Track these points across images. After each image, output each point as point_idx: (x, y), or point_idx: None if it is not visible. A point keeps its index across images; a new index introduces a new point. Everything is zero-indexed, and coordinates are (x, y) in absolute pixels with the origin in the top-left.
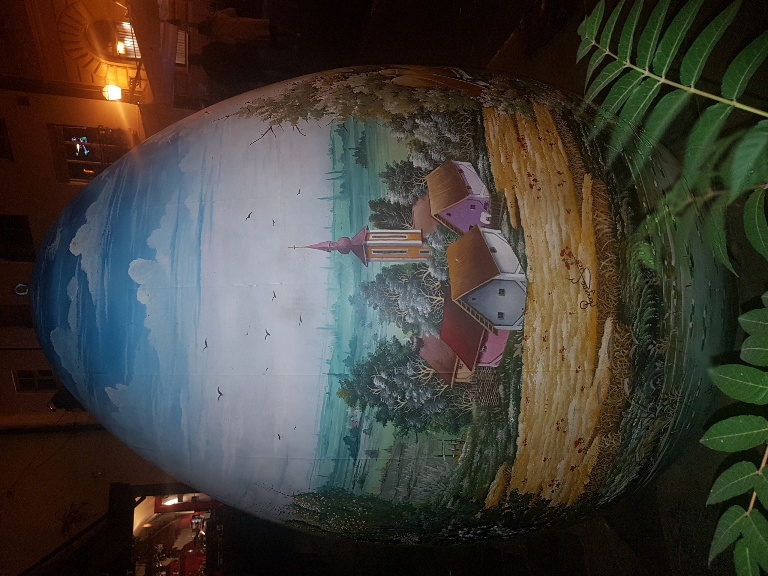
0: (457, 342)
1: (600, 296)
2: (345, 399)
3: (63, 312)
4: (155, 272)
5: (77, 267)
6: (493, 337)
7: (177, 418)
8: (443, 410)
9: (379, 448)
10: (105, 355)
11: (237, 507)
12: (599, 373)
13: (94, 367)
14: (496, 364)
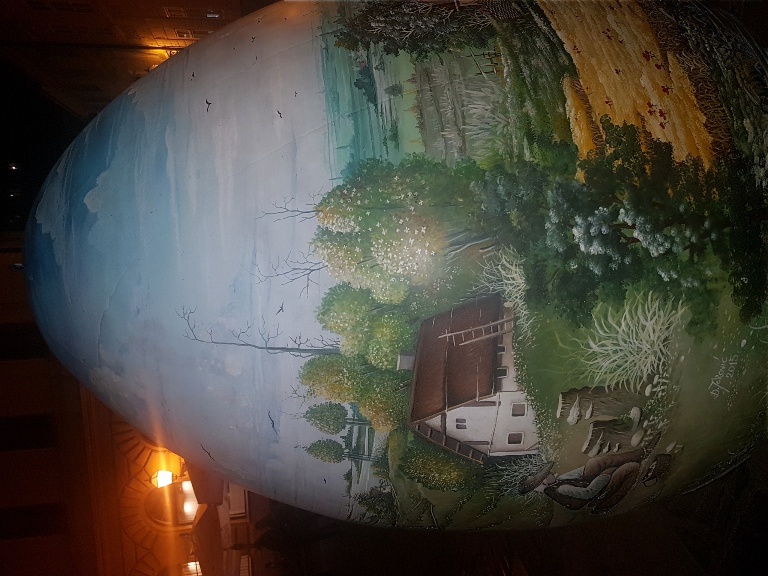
0: None
1: None
2: (345, 46)
3: (54, 173)
4: None
5: None
6: None
7: (162, 166)
8: (458, 29)
9: (400, 81)
10: (89, 158)
11: (253, 340)
12: None
13: (76, 185)
14: None
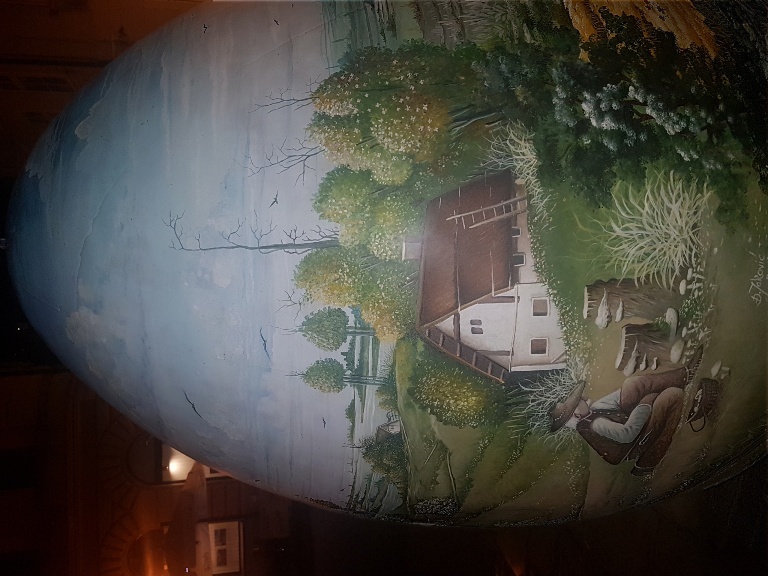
0: None
1: None
2: None
3: None
4: None
5: None
6: None
7: (156, 83)
8: None
9: None
10: None
11: (244, 240)
12: None
13: (68, 123)
14: None
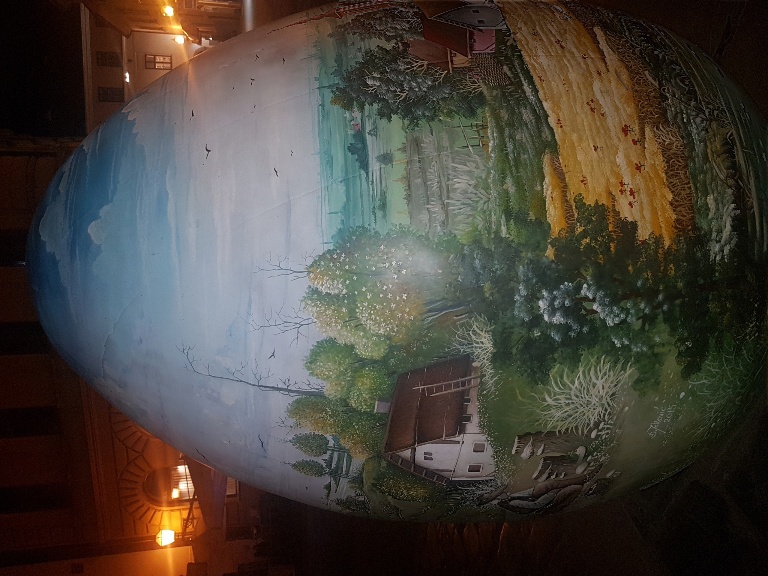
0: (443, 40)
1: (577, 16)
2: (340, 105)
3: (55, 189)
4: (146, 97)
5: (75, 149)
6: (479, 34)
7: (163, 209)
8: (450, 94)
9: (391, 149)
10: (91, 186)
11: (246, 378)
12: (610, 62)
13: (79, 212)
14: (491, 51)
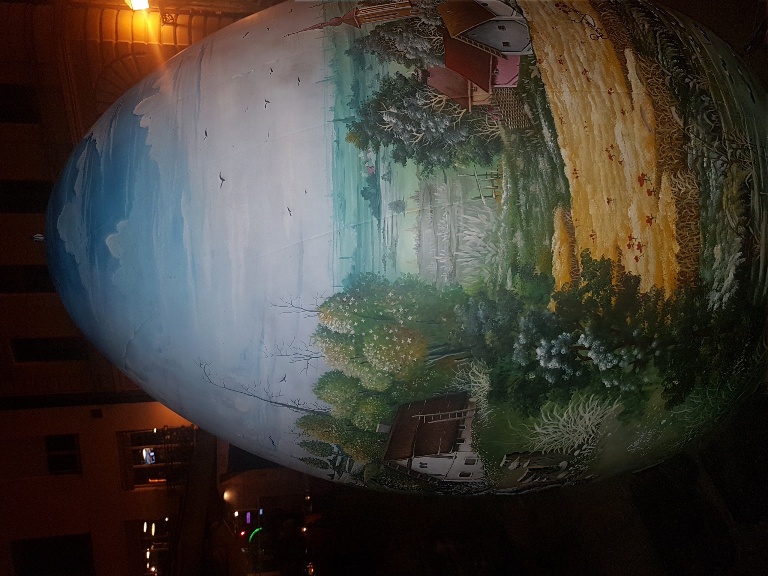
0: (465, 68)
1: (610, 33)
2: (355, 143)
3: (71, 187)
4: (158, 100)
5: (88, 142)
6: (503, 61)
7: (179, 235)
8: (467, 138)
9: (404, 197)
10: (107, 197)
11: (259, 394)
12: (637, 97)
13: (96, 221)
14: (514, 85)
